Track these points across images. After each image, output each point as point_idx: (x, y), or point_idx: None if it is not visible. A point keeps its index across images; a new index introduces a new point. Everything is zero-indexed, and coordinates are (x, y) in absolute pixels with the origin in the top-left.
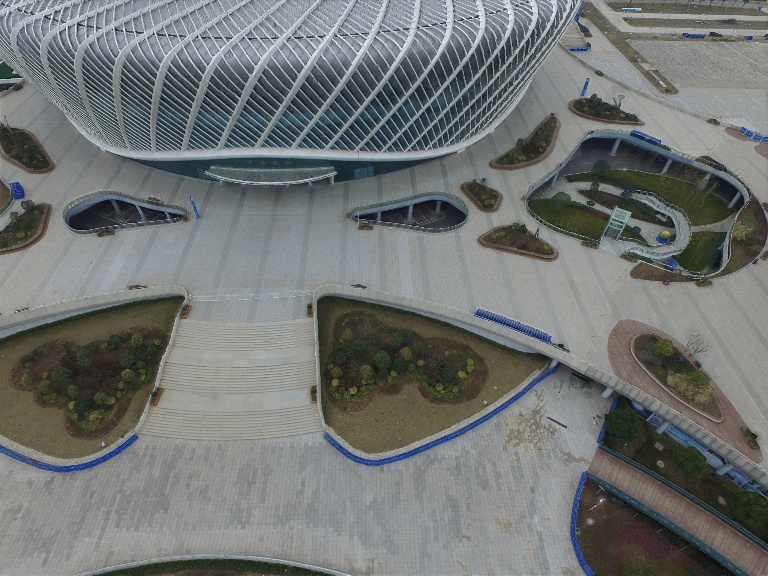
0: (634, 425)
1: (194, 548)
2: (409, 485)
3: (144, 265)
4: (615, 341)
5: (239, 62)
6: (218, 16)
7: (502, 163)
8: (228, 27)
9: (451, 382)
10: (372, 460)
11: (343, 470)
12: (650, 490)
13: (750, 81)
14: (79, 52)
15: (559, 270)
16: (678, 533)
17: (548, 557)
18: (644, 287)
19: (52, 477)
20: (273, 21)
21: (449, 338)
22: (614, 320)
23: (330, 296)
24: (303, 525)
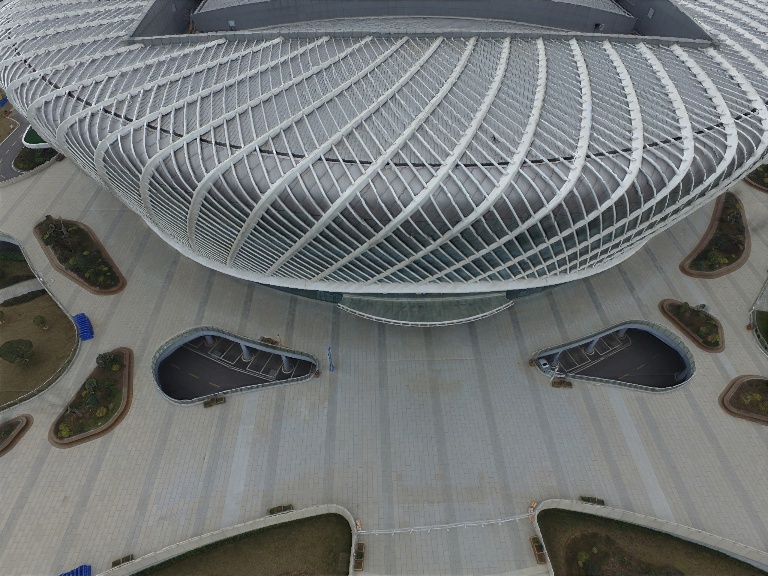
0: None
1: None
2: None
3: (278, 461)
4: None
5: (454, 203)
6: (412, 128)
7: (700, 269)
8: (429, 145)
9: None
10: None
11: None
12: None
13: None
14: (205, 184)
15: None
16: None
17: None
18: None
19: None
20: (490, 133)
21: None
22: None
23: None
24: None
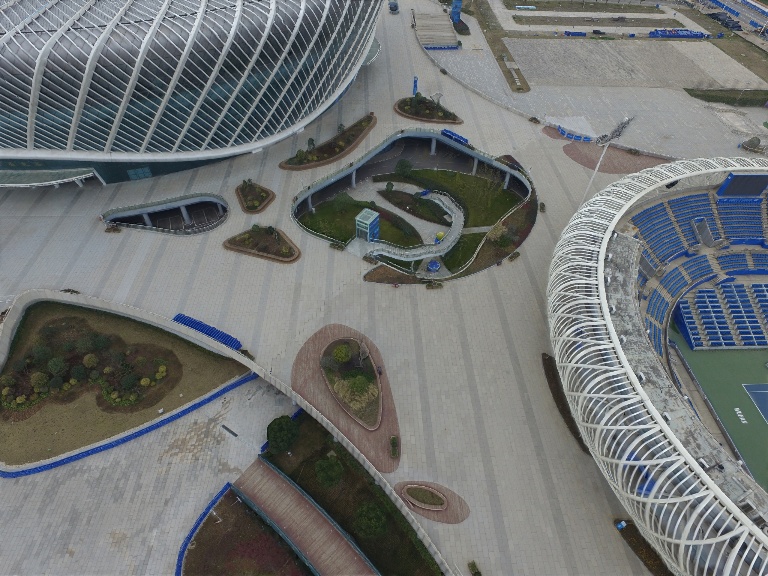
0: (281, 434)
1: None
2: (37, 498)
3: None
4: (309, 346)
5: None
6: None
7: (290, 163)
8: None
9: (130, 390)
10: (9, 472)
11: None
12: (287, 501)
13: (609, 79)
14: None
15: (292, 273)
16: (291, 546)
17: (146, 573)
18: (371, 290)
19: None
20: None
21: (155, 344)
22: (320, 324)
23: (46, 301)
24: None
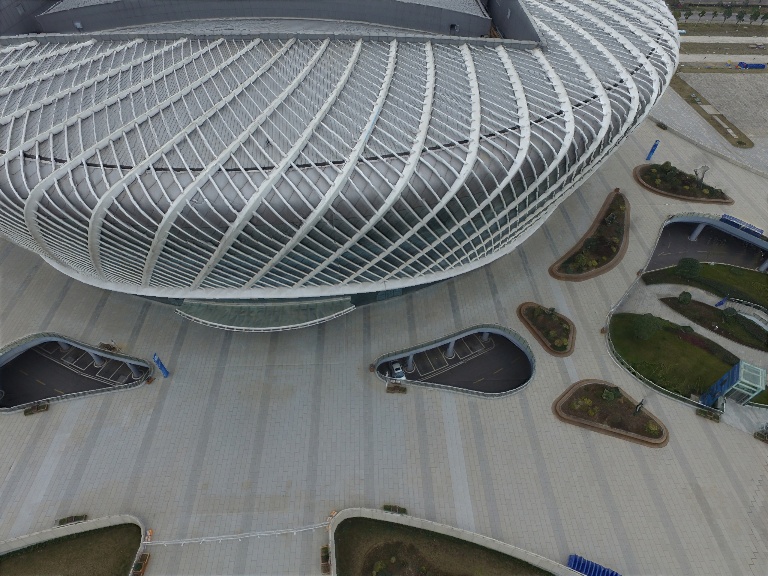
0: None
1: None
2: None
3: (86, 470)
4: None
5: (213, 209)
6: (181, 132)
7: (567, 272)
8: (196, 150)
9: None
10: None
11: None
12: None
13: None
14: None
15: (674, 465)
16: None
17: None
18: None
19: None
20: (265, 137)
21: None
22: None
23: None
24: None
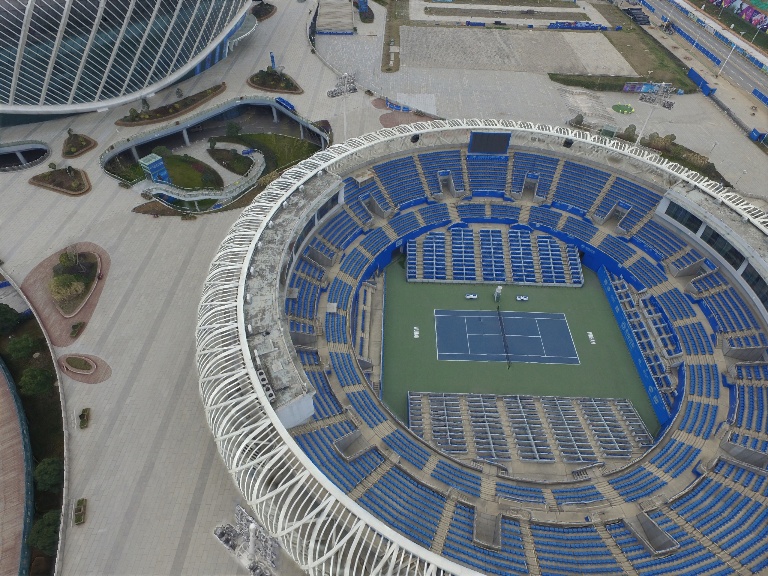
0: None
1: None
2: None
3: None
4: (55, 257)
5: None
6: None
7: (123, 120)
8: None
9: None
10: None
11: None
12: None
13: (480, 63)
14: None
15: (74, 203)
16: None
17: None
18: (133, 219)
19: None
20: None
21: None
22: (74, 242)
23: None
24: None
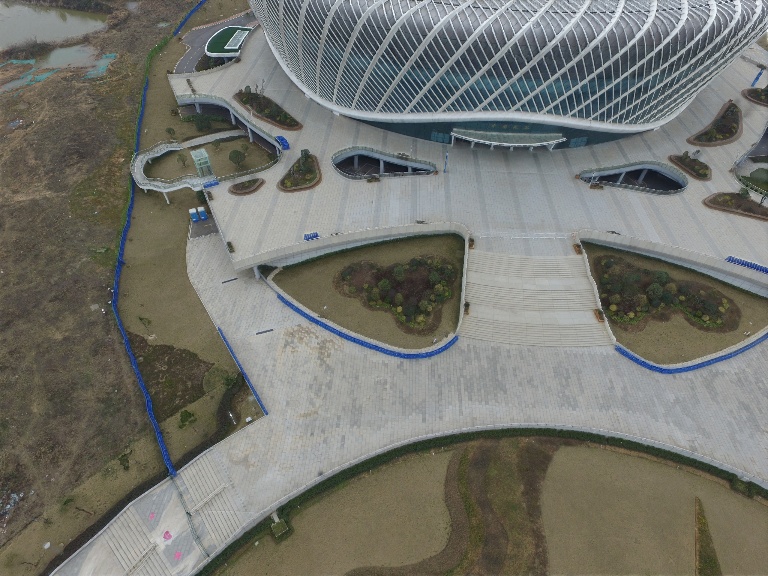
0: None
1: (540, 420)
2: (703, 390)
3: (417, 206)
4: None
5: (544, 32)
6: None
7: (701, 140)
8: (530, 2)
9: (714, 315)
10: None
11: (641, 375)
12: None
13: None
14: (402, 20)
15: None
16: None
17: None
18: None
19: (401, 361)
20: None
21: (697, 281)
22: None
23: (582, 241)
24: (624, 412)
